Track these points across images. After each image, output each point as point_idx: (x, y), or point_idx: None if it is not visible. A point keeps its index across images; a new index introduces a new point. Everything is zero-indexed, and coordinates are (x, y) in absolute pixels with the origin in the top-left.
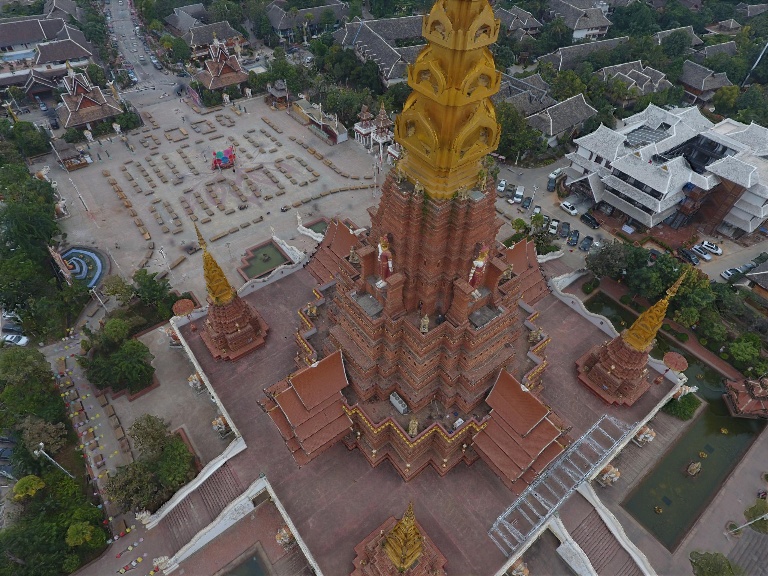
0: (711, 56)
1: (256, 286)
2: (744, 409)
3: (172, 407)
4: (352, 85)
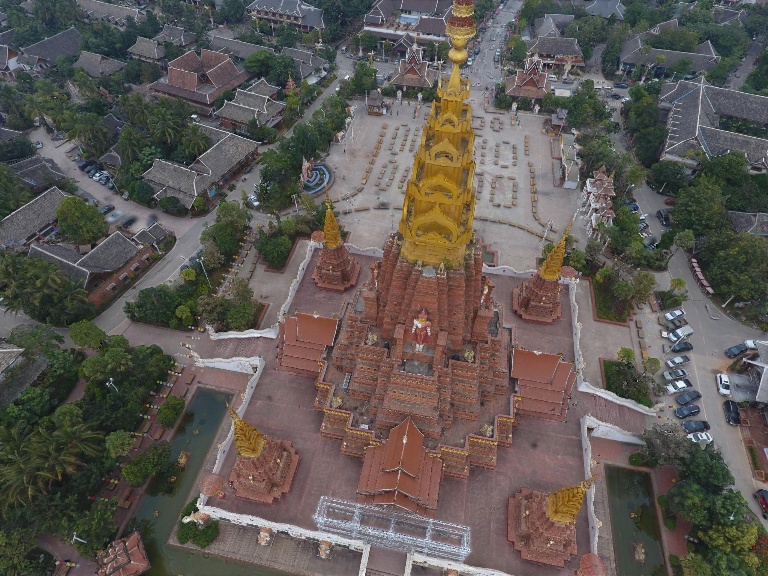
0: None
1: (377, 254)
2: None
3: (277, 290)
4: (636, 142)
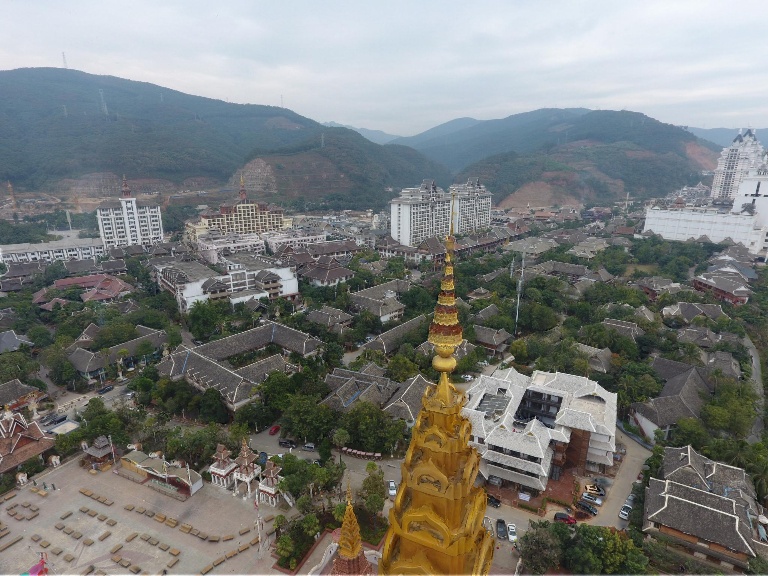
0: (486, 317)
1: None
2: None
3: None
4: (190, 415)
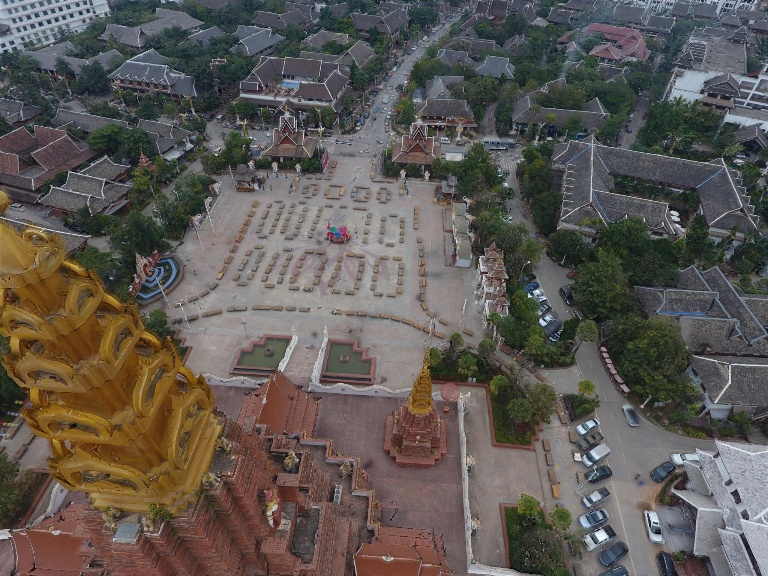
0: None
1: (214, 381)
2: None
3: None
4: (533, 207)
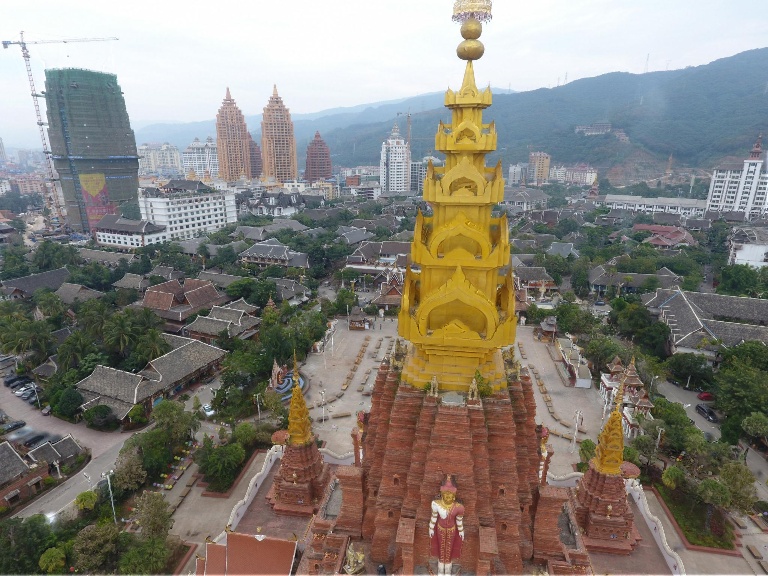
0: None
1: None
2: None
3: (214, 522)
4: (637, 344)
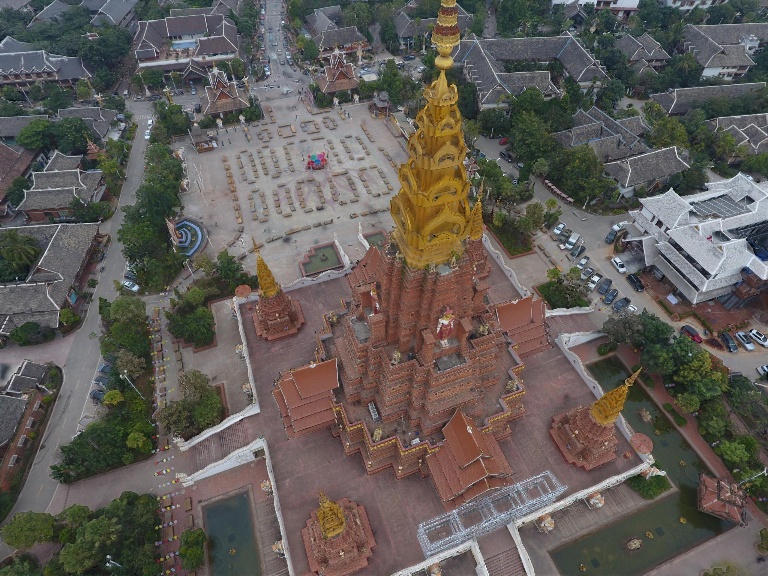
0: None
1: (306, 283)
2: (706, 506)
3: (221, 365)
4: None
